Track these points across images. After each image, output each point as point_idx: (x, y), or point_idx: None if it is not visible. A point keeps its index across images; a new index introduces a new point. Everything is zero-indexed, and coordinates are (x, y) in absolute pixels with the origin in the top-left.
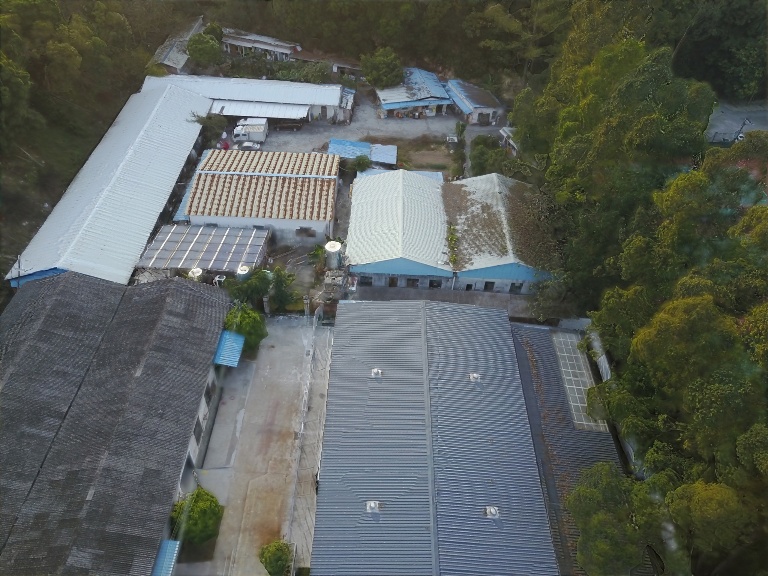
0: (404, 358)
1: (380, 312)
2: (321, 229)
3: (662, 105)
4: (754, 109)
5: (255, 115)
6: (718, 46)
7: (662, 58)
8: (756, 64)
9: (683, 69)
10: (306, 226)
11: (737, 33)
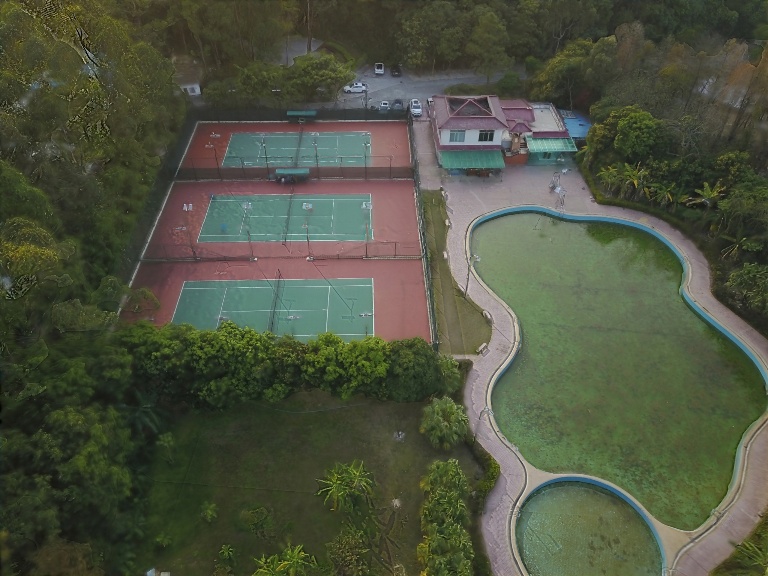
0: None
1: None
2: None
3: (22, 62)
4: (437, 78)
5: None
6: (394, 18)
7: (8, 18)
8: (421, 34)
9: (376, 43)
10: None
11: (411, 5)
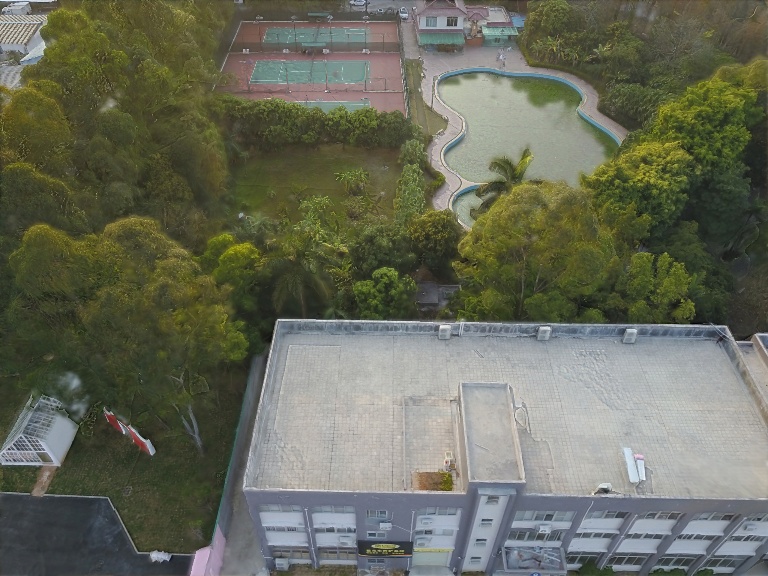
0: (4, 84)
1: (7, 70)
2: (22, 51)
3: None
4: None
5: (21, 0)
6: None
7: None
8: None
9: None
10: (12, 49)
11: None
